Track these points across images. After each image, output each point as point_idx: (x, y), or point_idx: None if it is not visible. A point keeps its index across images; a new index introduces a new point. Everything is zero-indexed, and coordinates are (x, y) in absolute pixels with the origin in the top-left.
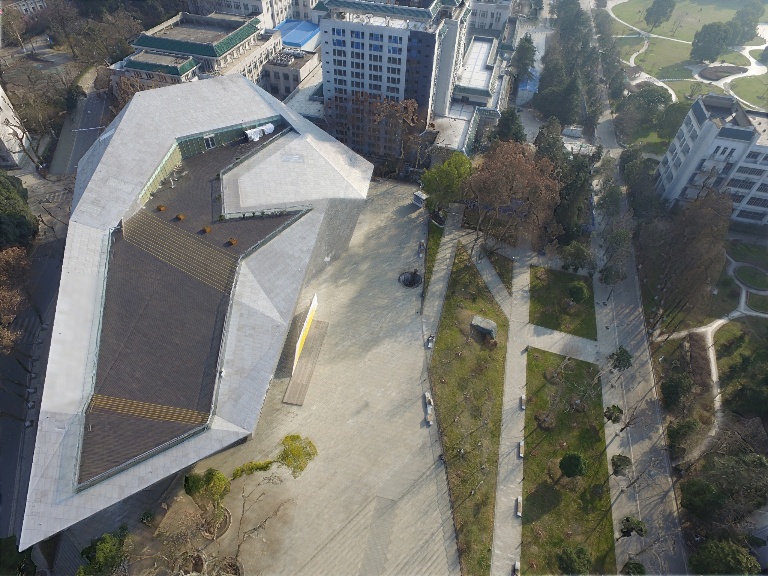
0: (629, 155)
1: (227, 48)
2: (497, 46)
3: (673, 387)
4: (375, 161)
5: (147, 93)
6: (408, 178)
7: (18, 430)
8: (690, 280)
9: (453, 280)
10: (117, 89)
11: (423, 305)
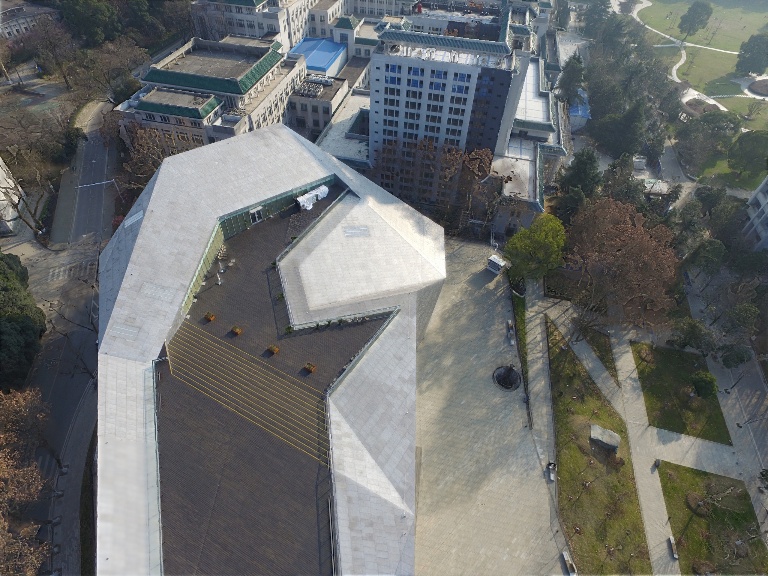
0: (710, 195)
1: (252, 82)
2: (543, 67)
3: None
4: (425, 208)
5: (177, 158)
6: (468, 230)
7: None
8: None
9: (554, 373)
10: (128, 137)
11: (530, 415)
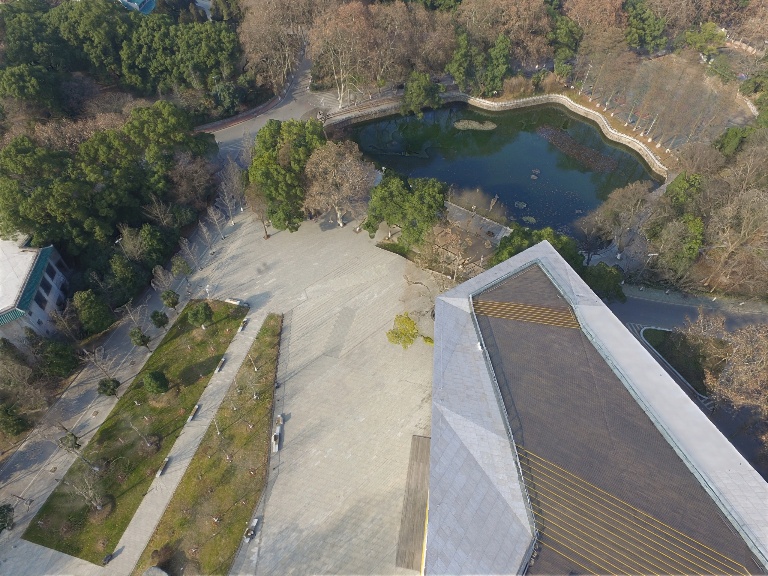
0: None
1: None
2: None
3: None
4: None
5: None
6: None
7: None
8: None
9: None
10: None
11: None
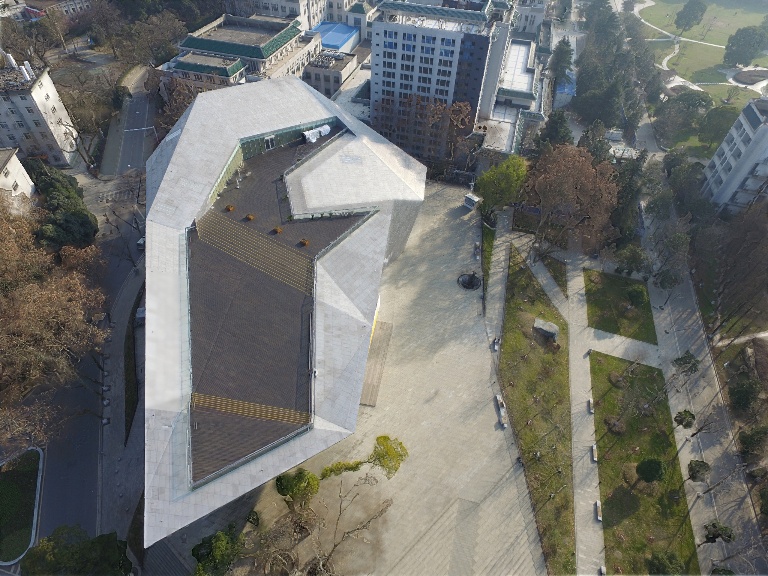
0: (674, 159)
1: (273, 50)
2: (535, 49)
3: (743, 393)
4: None
5: (209, 94)
6: (453, 180)
7: (96, 427)
8: (759, 285)
9: (510, 283)
10: (167, 90)
11: (485, 307)
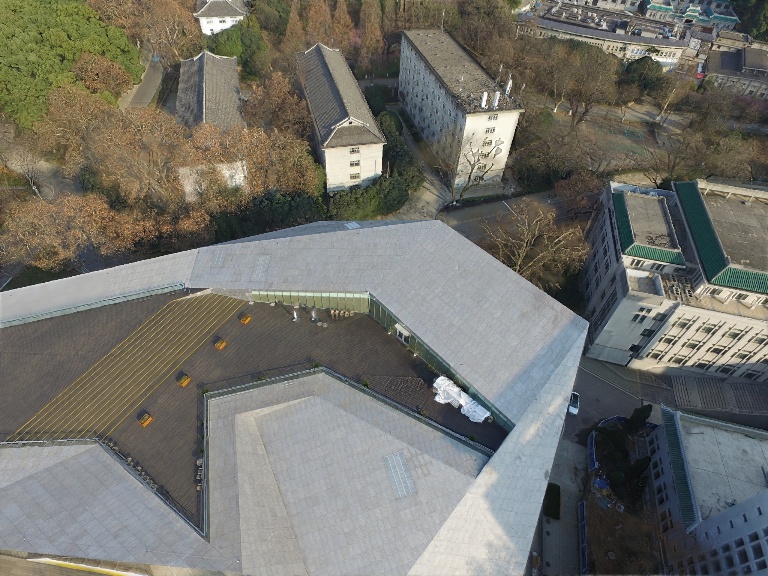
0: None
1: (754, 287)
2: None
3: None
4: None
5: (444, 230)
6: None
7: None
8: None
9: None
10: None
11: None
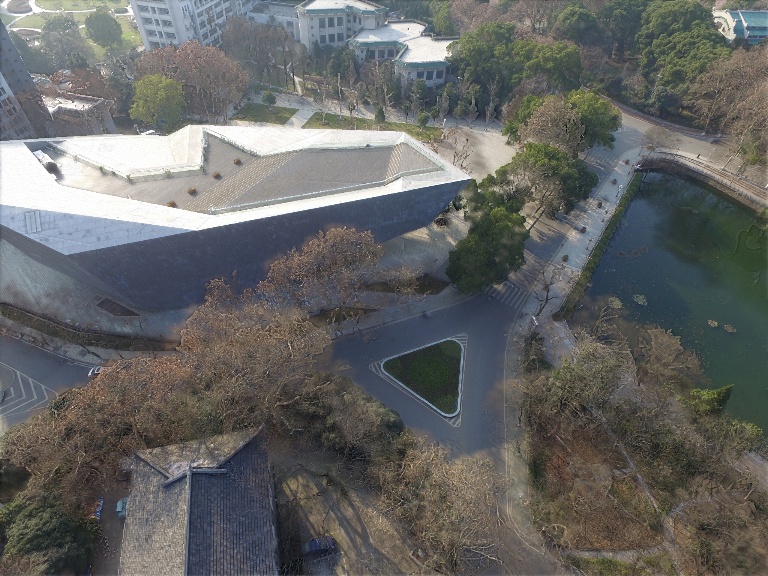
0: (131, 56)
1: None
2: None
3: None
4: None
5: None
6: None
7: None
8: (292, 47)
9: None
10: None
11: None
